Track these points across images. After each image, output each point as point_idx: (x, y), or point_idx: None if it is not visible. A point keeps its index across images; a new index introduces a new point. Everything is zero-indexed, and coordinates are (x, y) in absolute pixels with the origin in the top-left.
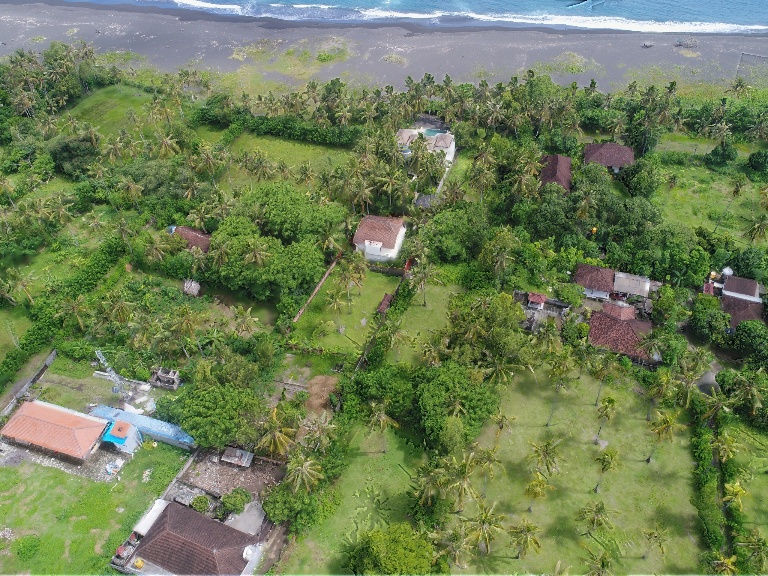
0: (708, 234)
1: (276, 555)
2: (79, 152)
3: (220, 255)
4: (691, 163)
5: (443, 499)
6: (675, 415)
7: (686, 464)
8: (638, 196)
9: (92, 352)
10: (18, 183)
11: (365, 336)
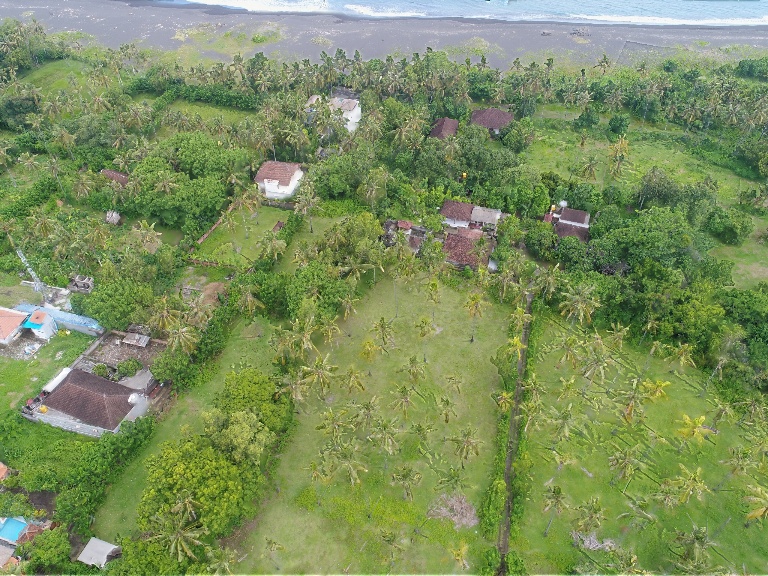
0: (557, 178)
1: (160, 408)
2: (22, 109)
3: (135, 187)
4: (563, 127)
5: None
6: (482, 294)
7: (502, 343)
8: (511, 152)
9: (20, 265)
10: None
11: (258, 254)
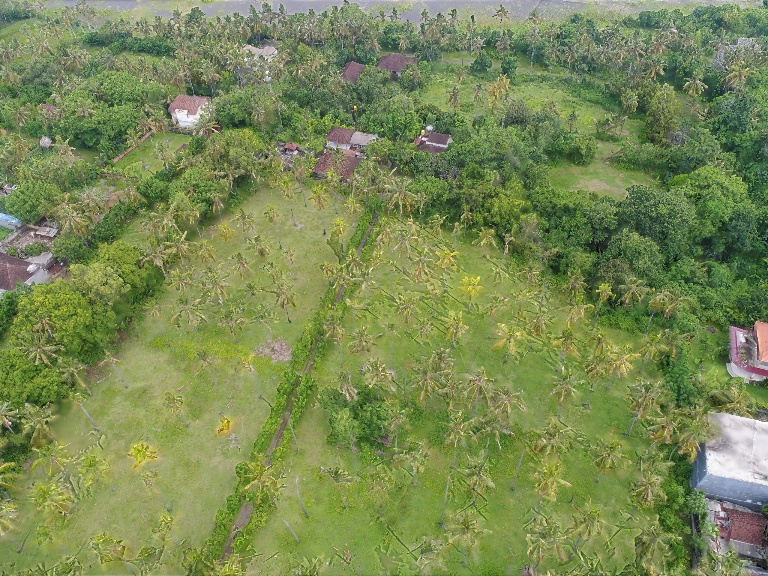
0: (434, 109)
1: None
2: None
3: (61, 113)
4: None
5: None
6: (323, 189)
7: (349, 235)
8: (407, 91)
9: None
10: None
11: None
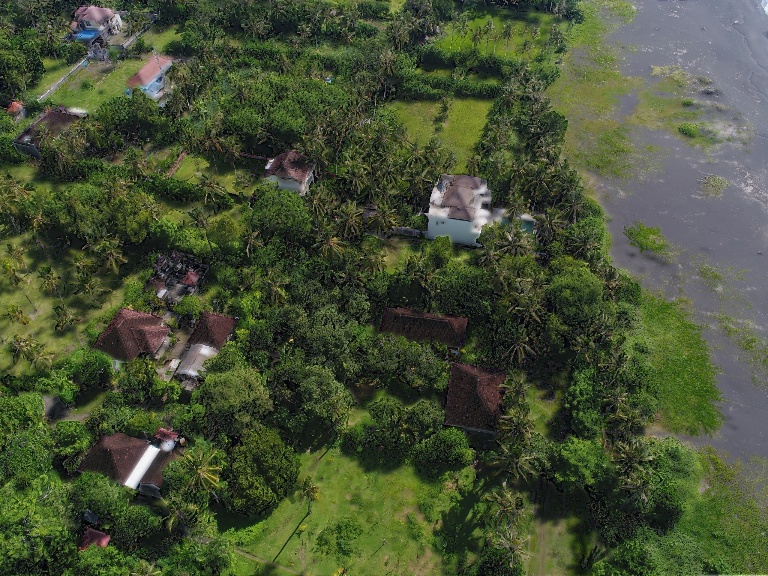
0: (257, 458)
1: None
2: None
3: None
4: (489, 529)
5: (29, 221)
6: None
7: None
8: None
9: None
10: (379, 7)
11: None
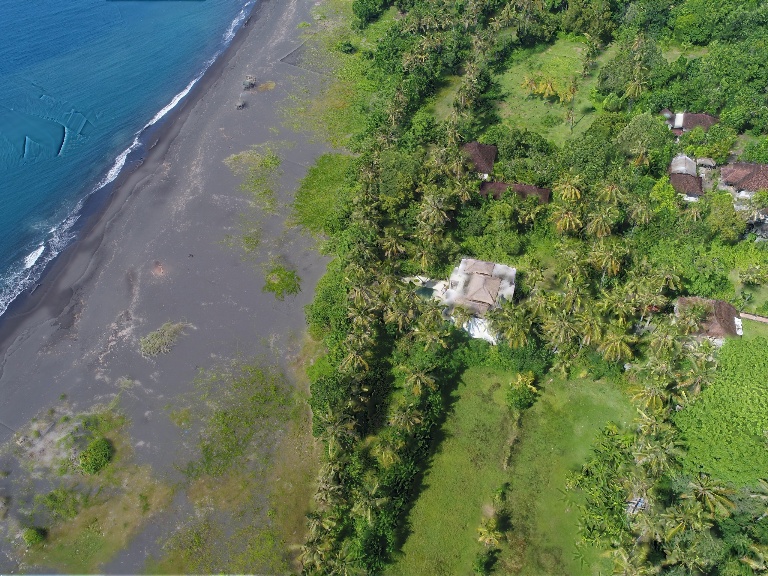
0: None
1: None
2: None
3: None
4: None
5: None
6: None
7: None
8: (534, 154)
9: None
10: None
11: None
